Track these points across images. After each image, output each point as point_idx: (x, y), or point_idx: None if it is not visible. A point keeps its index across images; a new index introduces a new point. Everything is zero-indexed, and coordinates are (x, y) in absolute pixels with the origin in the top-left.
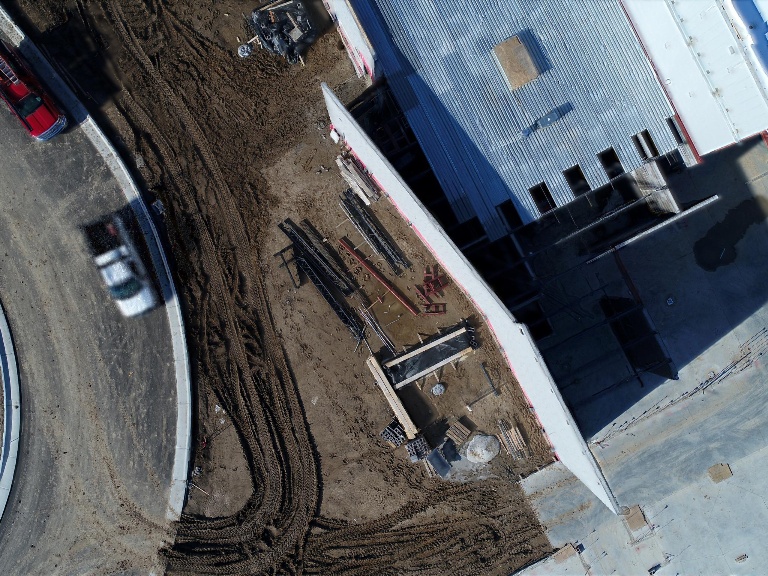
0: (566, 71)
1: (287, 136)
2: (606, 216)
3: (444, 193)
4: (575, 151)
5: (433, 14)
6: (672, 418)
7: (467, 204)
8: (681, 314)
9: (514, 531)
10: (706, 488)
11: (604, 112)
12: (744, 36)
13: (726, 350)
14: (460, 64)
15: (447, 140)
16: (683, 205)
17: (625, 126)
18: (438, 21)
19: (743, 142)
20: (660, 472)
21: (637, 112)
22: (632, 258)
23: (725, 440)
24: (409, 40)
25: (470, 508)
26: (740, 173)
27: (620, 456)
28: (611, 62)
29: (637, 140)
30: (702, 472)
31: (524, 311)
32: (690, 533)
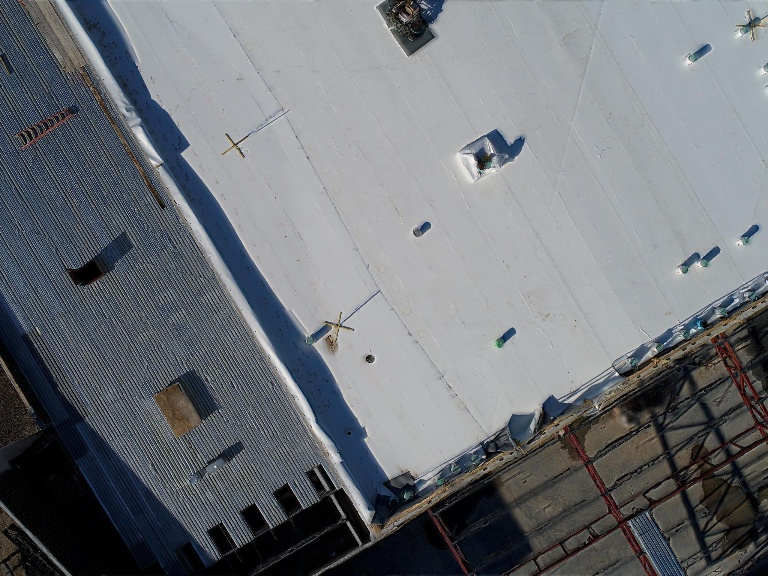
0: (235, 410)
1: (6, 440)
2: (287, 553)
3: (122, 539)
4: (251, 490)
5: (97, 360)
6: None
7: (147, 549)
8: None
9: None
10: None
11: (277, 449)
12: (333, 454)
13: None
14: (128, 409)
15: (121, 486)
16: (364, 538)
17: (299, 462)
18: (102, 367)
19: None
20: None
21: (310, 447)
22: None
23: None
24: (75, 388)
25: None
26: None
27: None
28: (280, 398)
29: (314, 474)
30: None
31: None
32: None
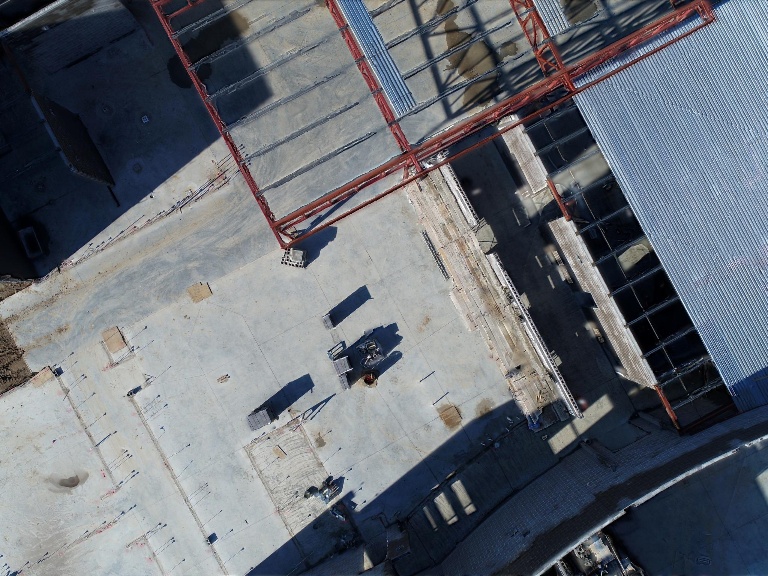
0: None
1: None
2: None
3: None
4: None
5: None
6: (149, 237)
7: None
8: (156, 132)
9: None
10: (186, 308)
11: None
12: None
13: (203, 167)
14: None
15: None
16: None
17: None
18: None
19: None
20: (139, 292)
21: None
22: (105, 76)
23: (204, 259)
24: None
25: None
26: None
27: (97, 277)
28: None
29: None
30: (181, 292)
31: None
32: (170, 354)
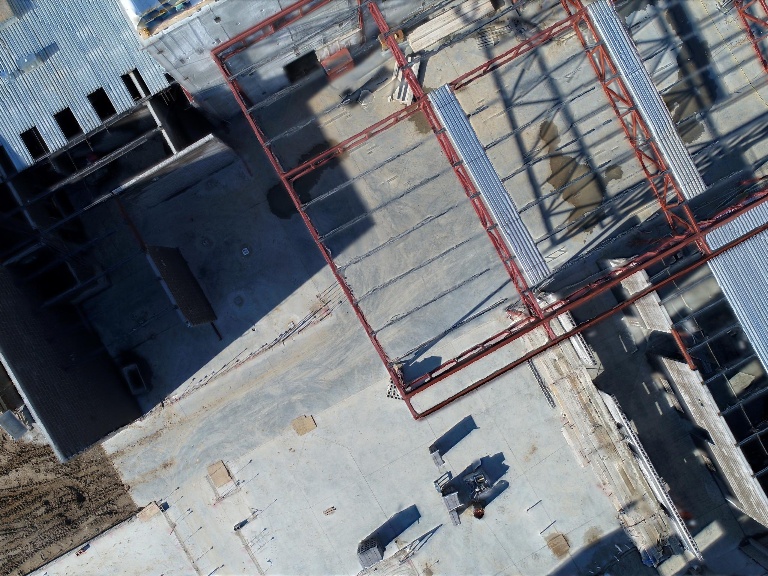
0: (51, 10)
1: None
2: (101, 160)
3: None
4: (65, 93)
5: None
6: (252, 371)
7: None
8: (257, 264)
9: (97, 491)
10: (290, 441)
11: (92, 52)
12: None
13: (305, 299)
14: None
15: None
16: (179, 146)
17: (114, 65)
18: None
19: (313, 84)
20: (243, 426)
21: (126, 50)
22: (205, 208)
23: (308, 391)
24: None
25: (54, 470)
26: (312, 117)
27: (201, 411)
28: None
29: (130, 80)
30: (285, 425)
31: (35, 262)
32: (276, 487)
